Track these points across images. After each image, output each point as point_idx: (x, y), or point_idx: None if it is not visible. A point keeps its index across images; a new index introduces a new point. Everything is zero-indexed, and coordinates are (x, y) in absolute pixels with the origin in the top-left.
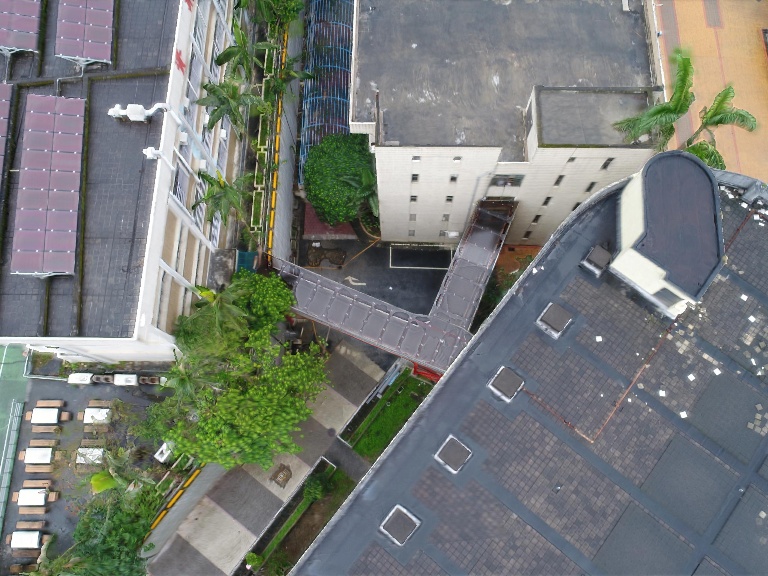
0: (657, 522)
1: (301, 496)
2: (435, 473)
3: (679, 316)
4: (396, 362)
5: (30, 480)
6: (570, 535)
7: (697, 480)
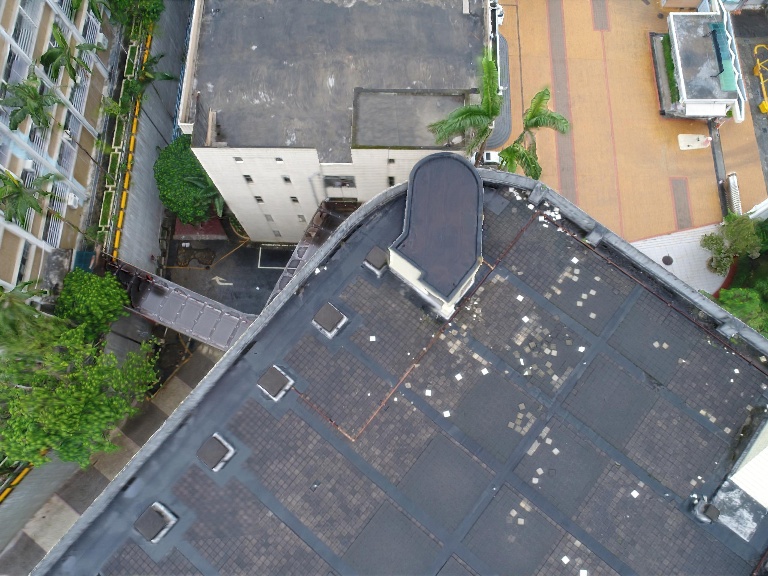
0: (409, 520)
1: None
2: (197, 471)
3: (453, 316)
4: None
5: None
6: (322, 533)
7: (453, 479)
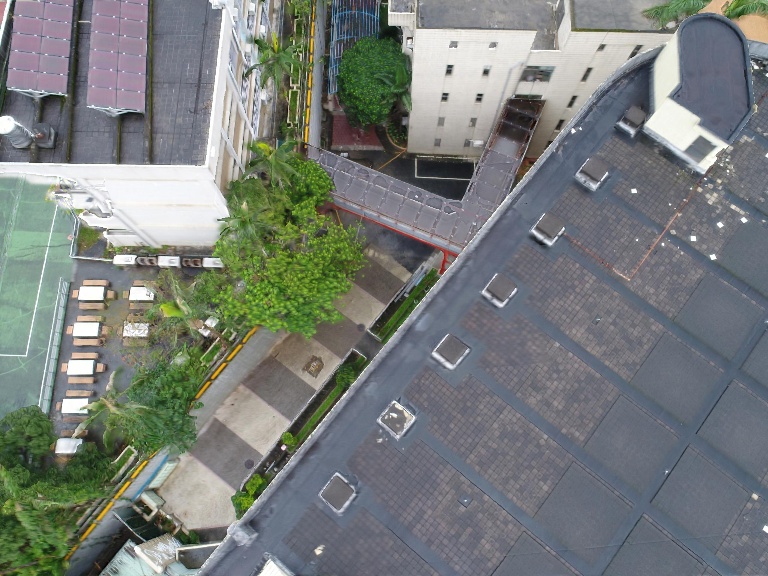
0: (689, 350)
1: (333, 385)
2: (483, 307)
3: (708, 171)
4: (422, 265)
5: (78, 352)
6: (609, 361)
7: (726, 313)
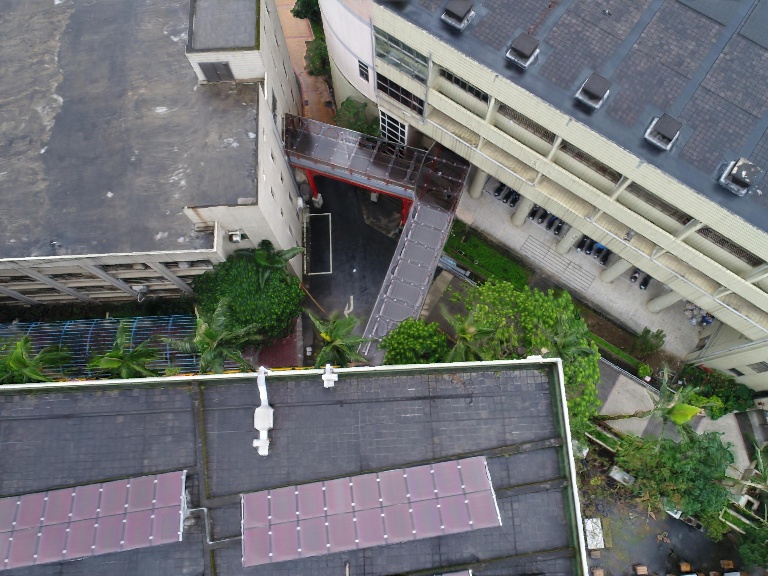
0: None
1: None
2: (611, 108)
3: None
4: None
5: None
6: (643, 5)
7: None
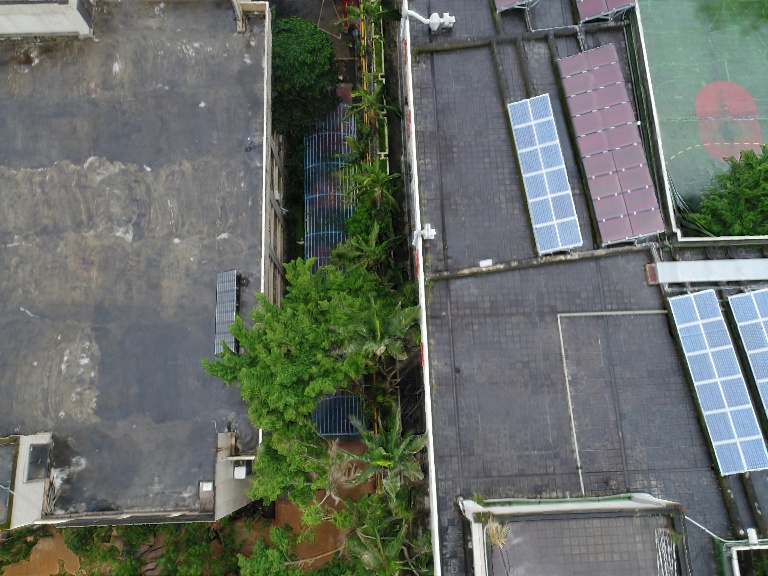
0: None
1: None
2: None
3: None
4: None
5: None
6: None
7: None
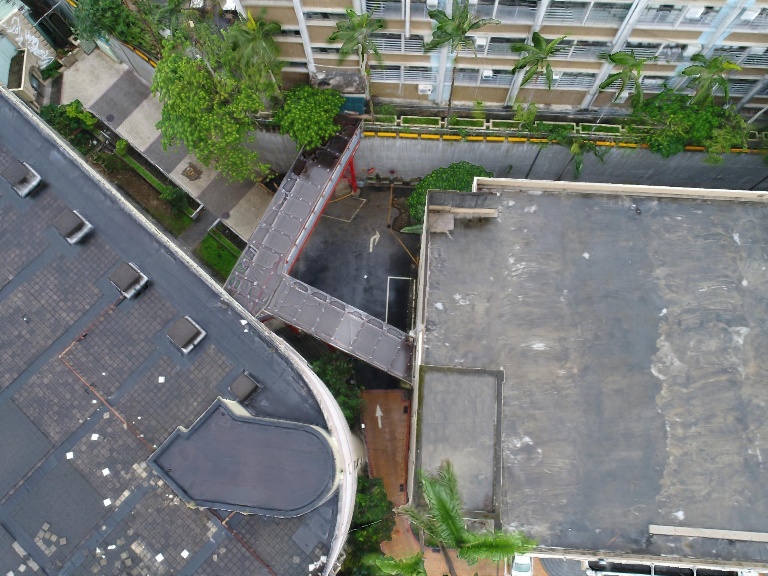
0: None
1: None
2: (62, 211)
3: None
4: None
5: None
6: None
7: (5, 457)
